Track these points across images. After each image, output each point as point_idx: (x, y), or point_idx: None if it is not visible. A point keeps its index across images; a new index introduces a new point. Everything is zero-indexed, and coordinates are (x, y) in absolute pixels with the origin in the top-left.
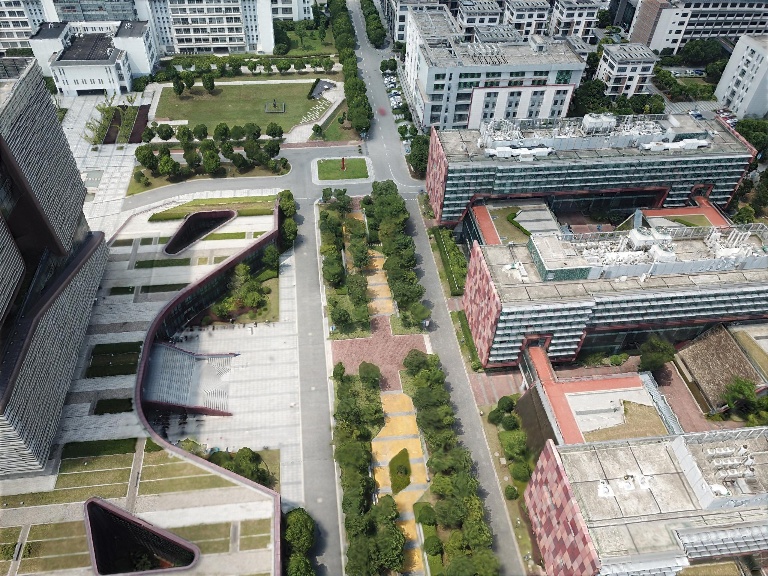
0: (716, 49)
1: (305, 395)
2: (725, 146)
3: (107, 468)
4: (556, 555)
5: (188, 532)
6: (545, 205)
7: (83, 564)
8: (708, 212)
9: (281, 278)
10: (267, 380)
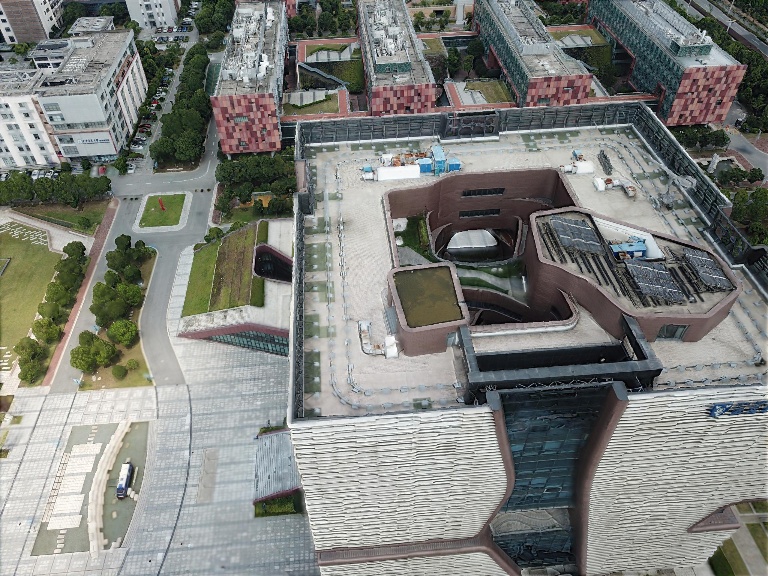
0: (81, 6)
1: None
2: (272, 6)
3: None
4: None
5: None
6: (284, 93)
7: None
8: (304, 43)
9: None
10: None
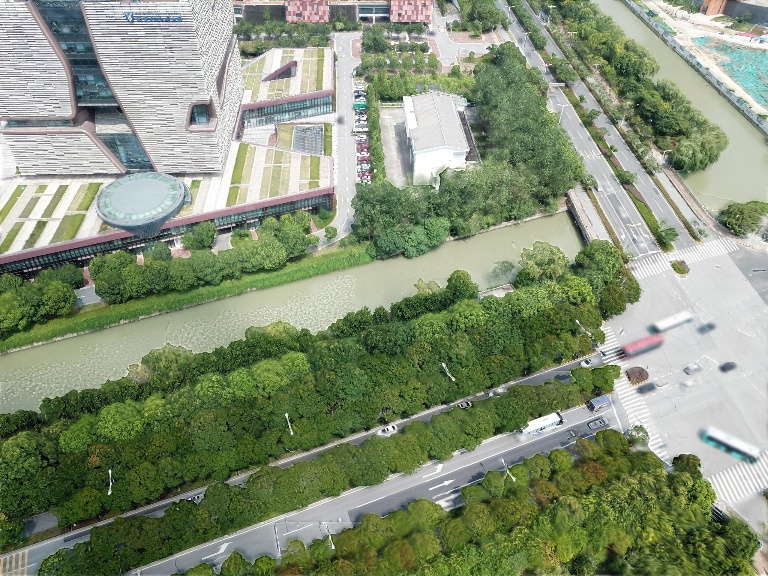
0: None
1: None
2: None
3: None
4: None
5: (283, 63)
6: None
7: (289, 80)
8: None
9: None
10: None
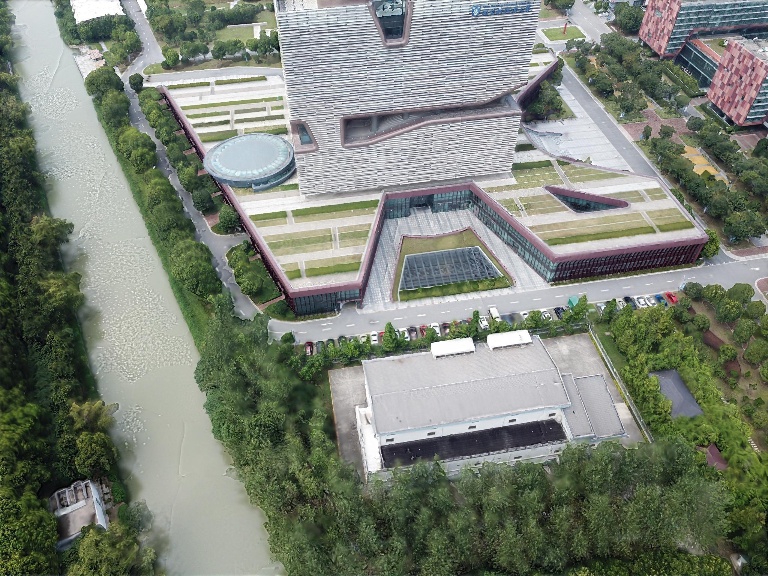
0: None
1: (621, 151)
2: None
3: (542, 173)
4: None
5: (615, 195)
6: (741, 36)
7: (563, 210)
8: None
9: (562, 96)
10: (590, 146)
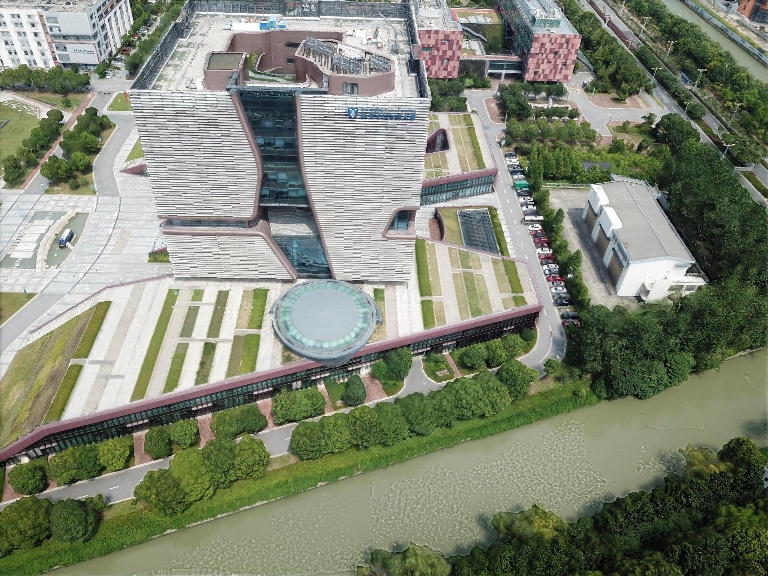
0: None
1: None
2: None
3: None
4: (443, 62)
5: (430, 131)
6: None
7: (444, 154)
8: None
9: None
10: None
